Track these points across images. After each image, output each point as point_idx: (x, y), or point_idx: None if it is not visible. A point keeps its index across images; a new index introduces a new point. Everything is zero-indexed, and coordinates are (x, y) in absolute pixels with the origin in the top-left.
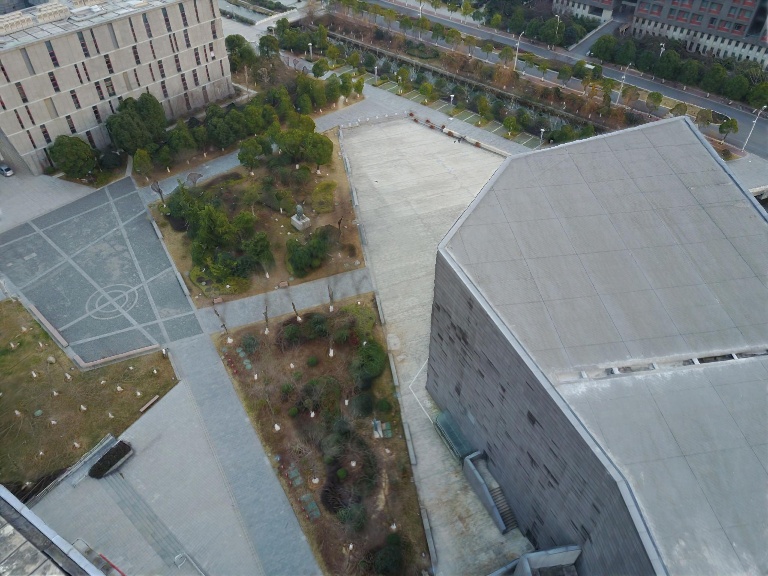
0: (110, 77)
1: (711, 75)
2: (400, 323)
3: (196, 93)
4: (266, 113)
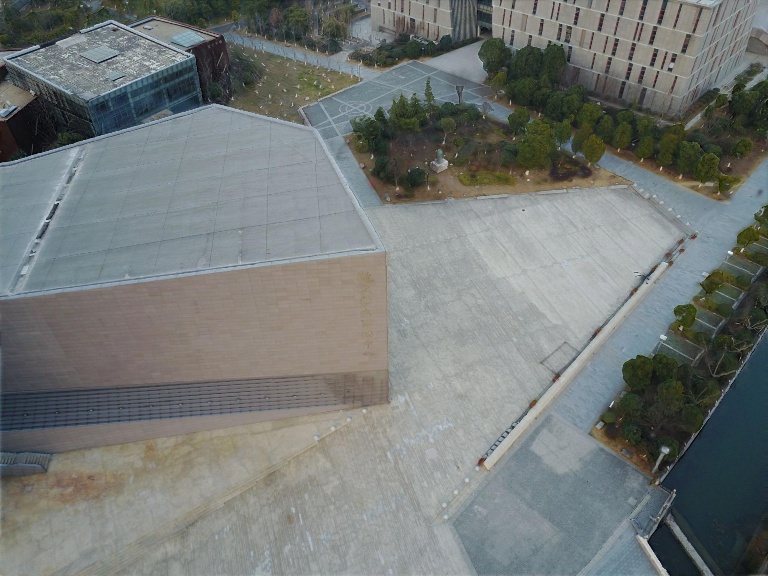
0: (572, 27)
1: None
2: None
3: (634, 88)
4: (601, 122)
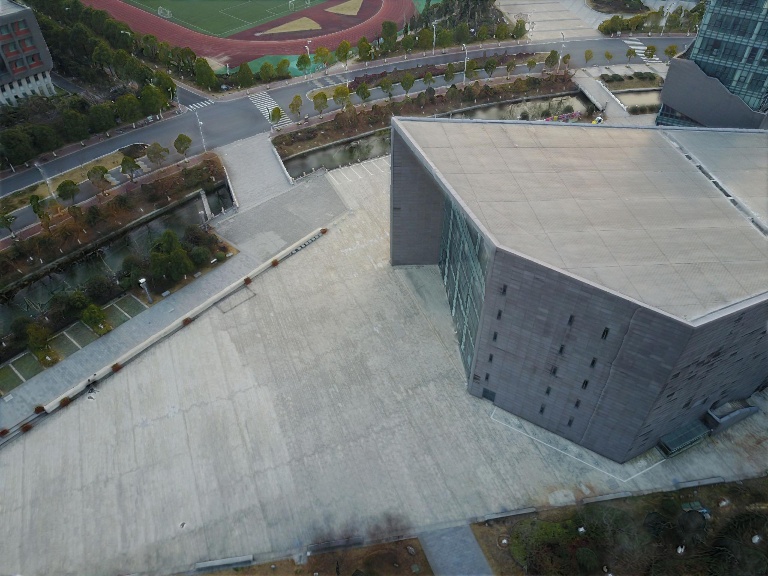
0: None
1: (73, 124)
2: (528, 489)
3: None
4: None
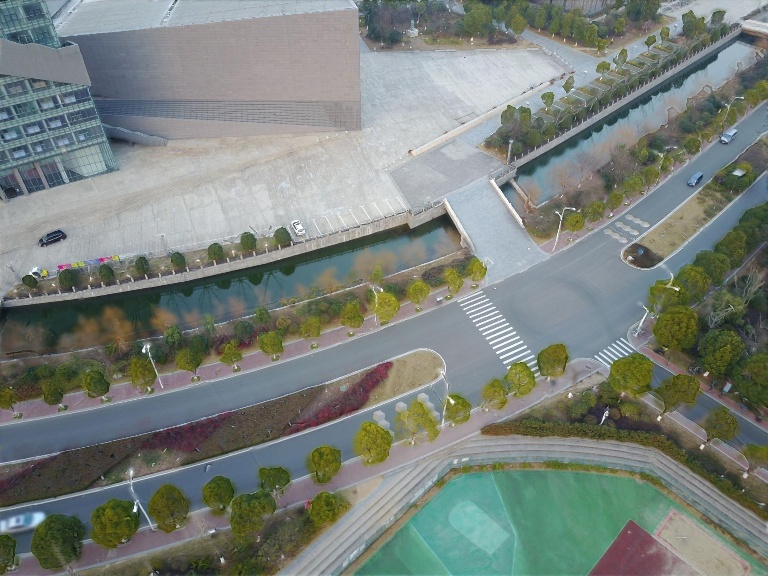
0: None
1: None
2: None
3: None
4: (527, 10)
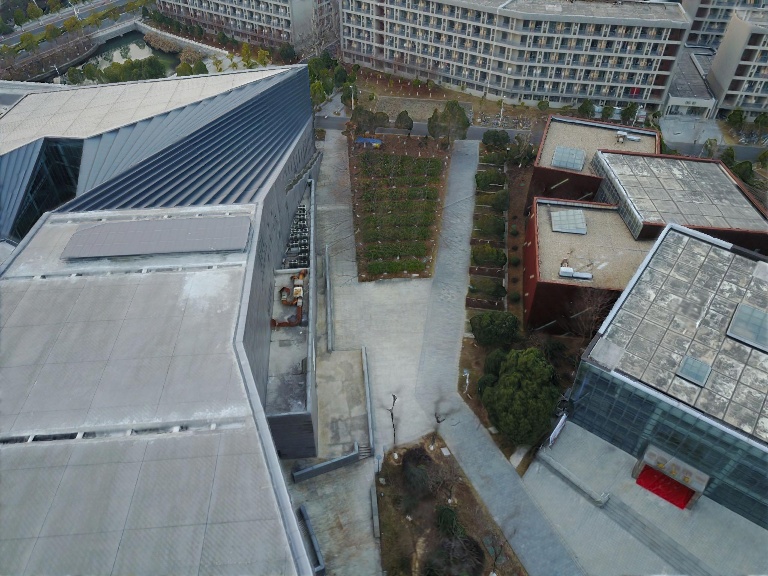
0: None
1: None
2: None
3: None
4: None
